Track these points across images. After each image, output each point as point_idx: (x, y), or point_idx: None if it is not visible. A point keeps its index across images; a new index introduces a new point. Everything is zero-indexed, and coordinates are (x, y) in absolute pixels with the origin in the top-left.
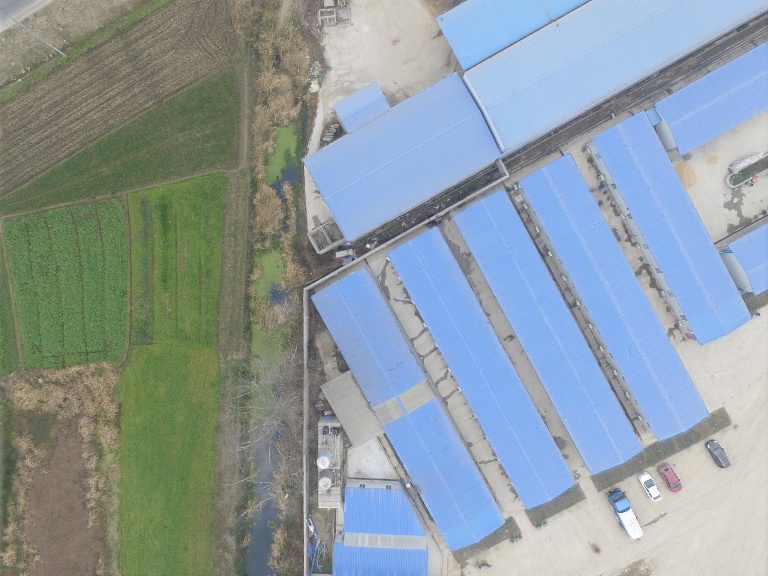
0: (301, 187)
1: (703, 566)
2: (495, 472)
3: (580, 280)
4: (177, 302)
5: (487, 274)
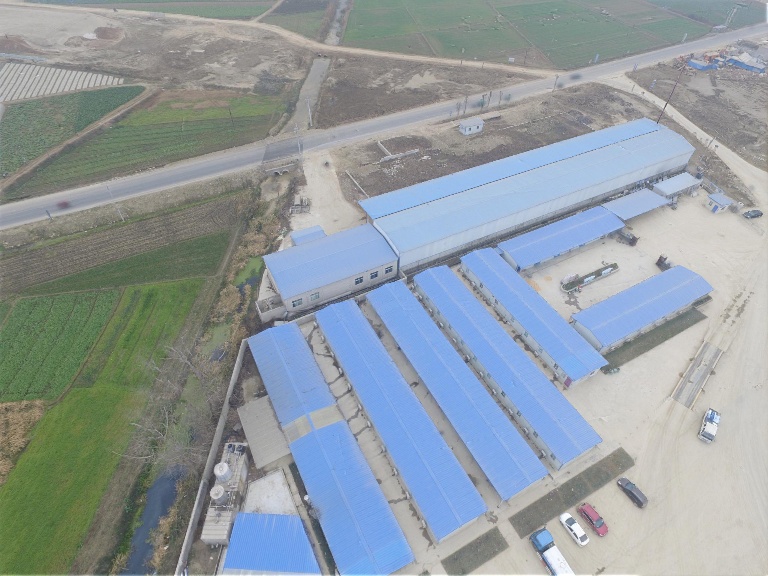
0: (258, 285)
1: None
2: (405, 513)
3: (464, 333)
4: (130, 356)
5: (391, 329)
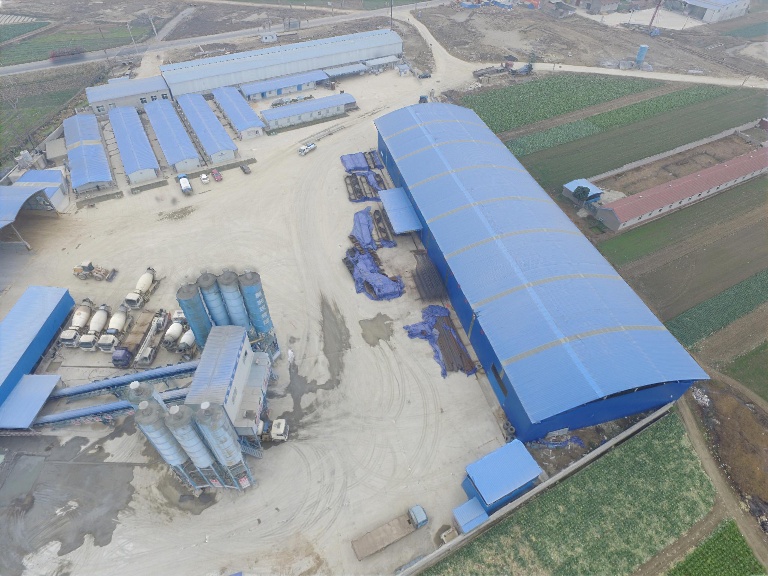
0: None
1: (226, 208)
2: None
3: None
4: None
5: (149, 116)
